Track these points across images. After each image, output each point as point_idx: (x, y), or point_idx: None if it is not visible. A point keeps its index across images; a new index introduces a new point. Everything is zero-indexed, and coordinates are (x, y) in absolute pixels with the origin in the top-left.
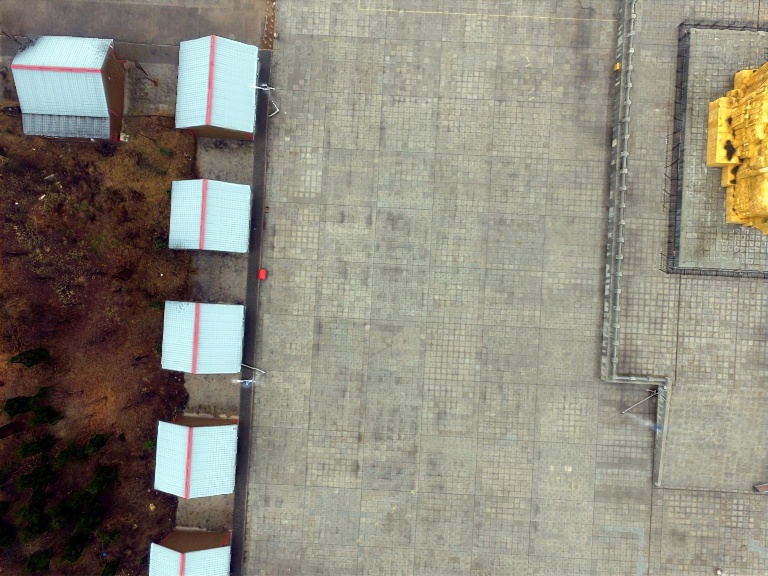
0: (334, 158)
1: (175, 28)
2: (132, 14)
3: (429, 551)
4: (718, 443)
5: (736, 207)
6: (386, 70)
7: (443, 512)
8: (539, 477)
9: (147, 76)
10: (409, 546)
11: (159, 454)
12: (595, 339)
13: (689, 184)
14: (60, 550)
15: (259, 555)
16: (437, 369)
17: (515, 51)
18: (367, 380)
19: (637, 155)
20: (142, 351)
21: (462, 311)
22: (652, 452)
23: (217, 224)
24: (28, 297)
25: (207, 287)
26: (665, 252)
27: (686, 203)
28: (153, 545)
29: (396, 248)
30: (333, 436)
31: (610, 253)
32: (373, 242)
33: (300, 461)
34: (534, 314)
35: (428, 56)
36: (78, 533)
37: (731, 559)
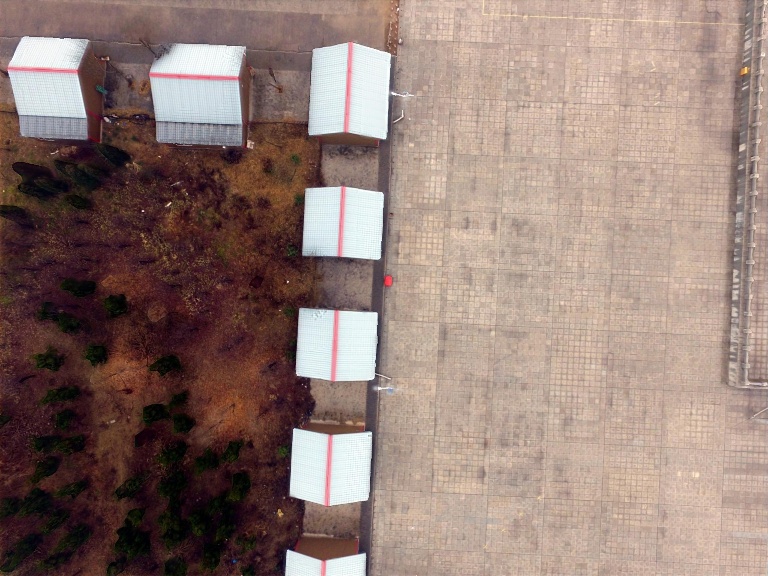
0: (458, 164)
1: (299, 35)
2: (256, 21)
3: (556, 557)
4: None
5: None
6: (510, 75)
7: (570, 518)
8: (666, 483)
9: (272, 83)
10: (536, 552)
11: (295, 461)
12: (722, 344)
13: None
14: (190, 557)
15: (386, 561)
16: (563, 375)
17: (640, 56)
18: (493, 386)
19: (767, 160)
20: (269, 358)
21: (588, 317)
22: None
23: (354, 231)
24: (155, 304)
25: (332, 294)
26: None
27: None
28: (289, 552)
29: (521, 254)
30: (459, 442)
31: (739, 258)
32: (498, 248)
33: (426, 467)
34: (660, 320)
35: (553, 61)
36: (209, 540)
37: None
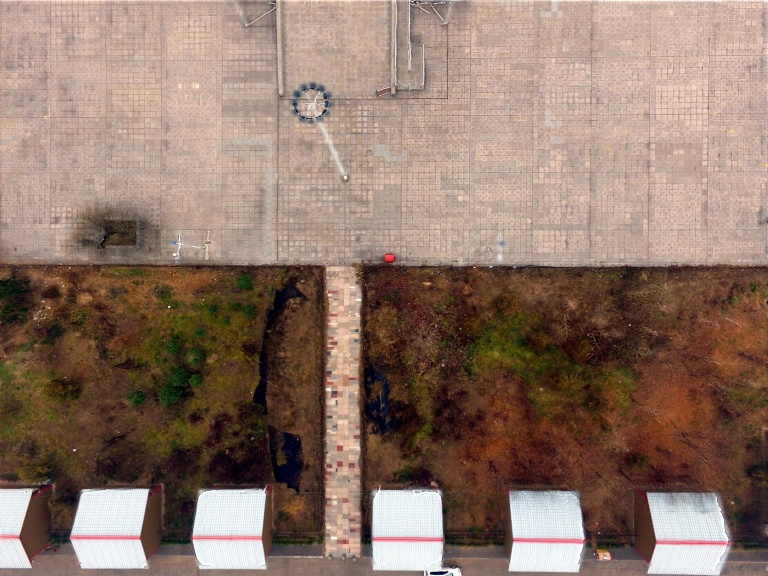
0: None
1: None
2: None
3: (64, 174)
4: (337, 47)
5: None
6: None
7: (76, 136)
8: (168, 96)
9: None
10: (45, 171)
11: None
12: None
13: None
14: None
15: None
16: None
17: None
18: None
19: None
20: None
21: None
22: None
23: None
24: None
25: None
26: None
27: None
28: None
29: None
30: None
31: None
32: None
33: None
34: None
35: None
36: None
37: (357, 164)
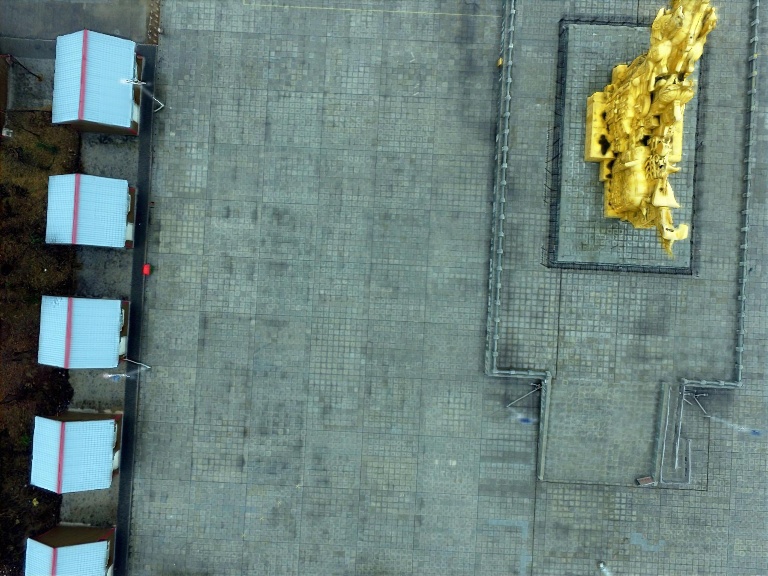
0: (219, 153)
1: (60, 23)
2: (16, 9)
3: (314, 545)
4: (600, 436)
5: (611, 201)
6: (271, 65)
7: (328, 506)
8: (424, 471)
9: (31, 71)
10: (294, 540)
11: (35, 449)
12: (479, 333)
13: (568, 179)
14: None
15: (144, 550)
16: (322, 364)
17: (400, 46)
18: (252, 375)
19: (518, 150)
20: (25, 346)
21: (347, 306)
22: (536, 446)
23: (91, 219)
24: None
25: (92, 282)
26: (546, 246)
27: (565, 198)
28: (29, 540)
29: (281, 243)
30: (218, 431)
31: (492, 248)
32: (258, 237)
33: (185, 456)
34: (419, 309)
35: (313, 51)
36: None
37: (614, 552)
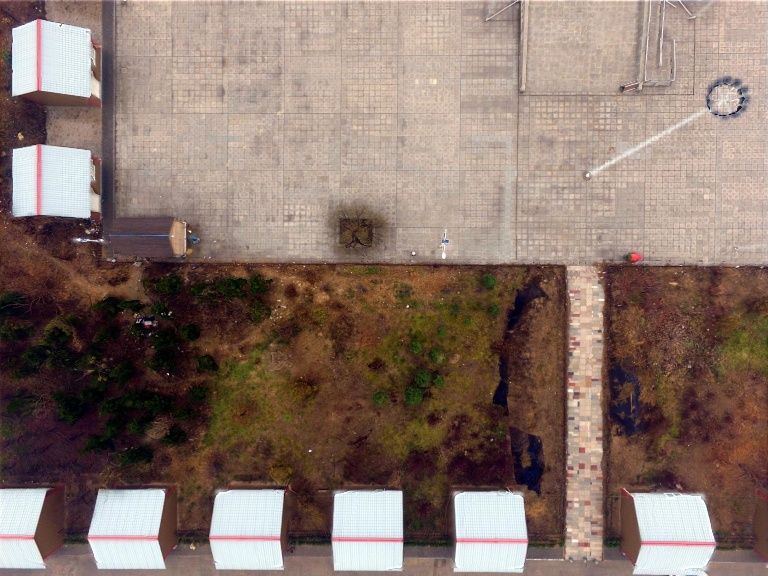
0: None
1: None
2: None
3: (298, 172)
4: (582, 42)
5: None
6: None
7: (310, 132)
8: (404, 92)
9: None
10: (278, 168)
11: (14, 61)
12: None
13: None
14: None
15: (130, 184)
16: None
17: None
18: (228, 4)
19: None
20: None
21: None
22: (517, 59)
23: None
24: None
25: None
26: None
27: None
28: (14, 151)
29: None
30: (197, 62)
31: None
32: None
33: (165, 89)
34: None
35: None
36: None
37: (600, 162)
